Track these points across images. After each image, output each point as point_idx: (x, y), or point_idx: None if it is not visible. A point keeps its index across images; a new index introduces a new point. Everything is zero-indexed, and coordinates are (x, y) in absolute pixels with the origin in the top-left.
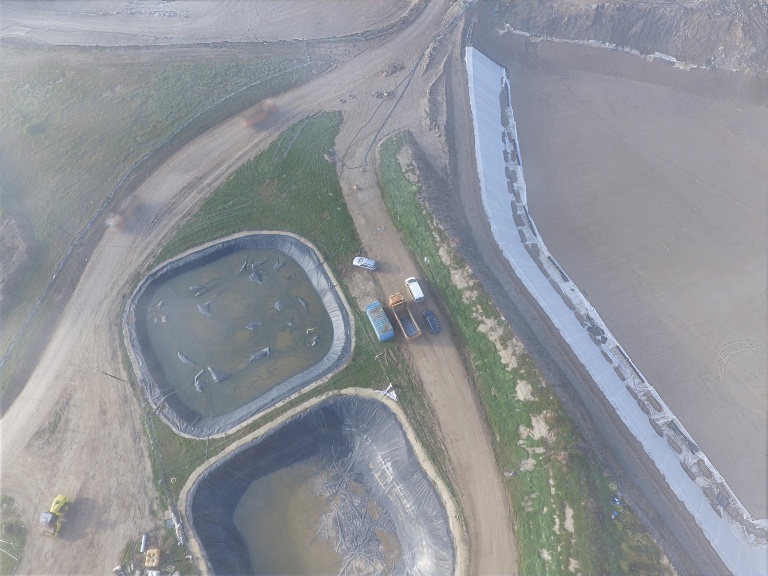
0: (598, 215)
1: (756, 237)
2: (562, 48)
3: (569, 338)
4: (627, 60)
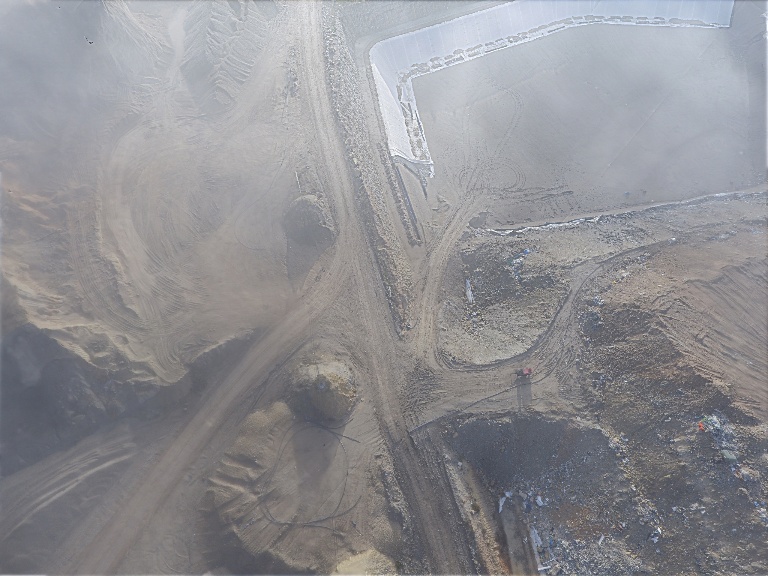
0: (605, 54)
1: (609, 130)
2: (763, 50)
3: (508, 5)
4: (767, 85)
